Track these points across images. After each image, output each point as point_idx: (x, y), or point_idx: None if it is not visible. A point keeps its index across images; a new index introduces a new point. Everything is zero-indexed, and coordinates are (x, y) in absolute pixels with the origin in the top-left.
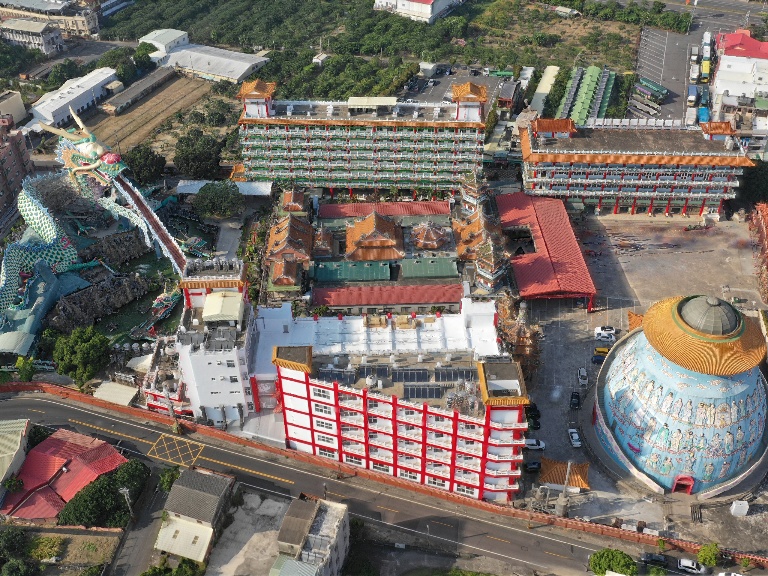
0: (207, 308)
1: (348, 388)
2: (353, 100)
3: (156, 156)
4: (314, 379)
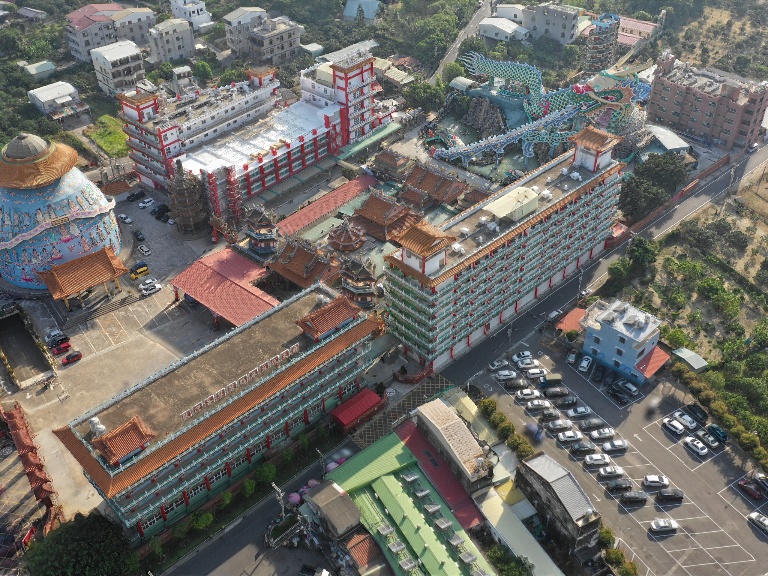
0: None
1: (227, 87)
2: (524, 189)
3: (663, 175)
4: (247, 81)
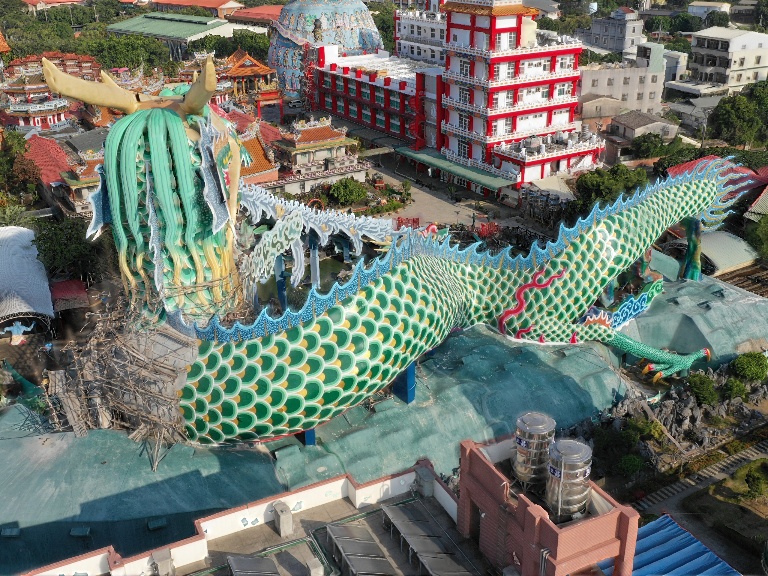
0: (524, 22)
1: None
2: None
3: None
4: None
